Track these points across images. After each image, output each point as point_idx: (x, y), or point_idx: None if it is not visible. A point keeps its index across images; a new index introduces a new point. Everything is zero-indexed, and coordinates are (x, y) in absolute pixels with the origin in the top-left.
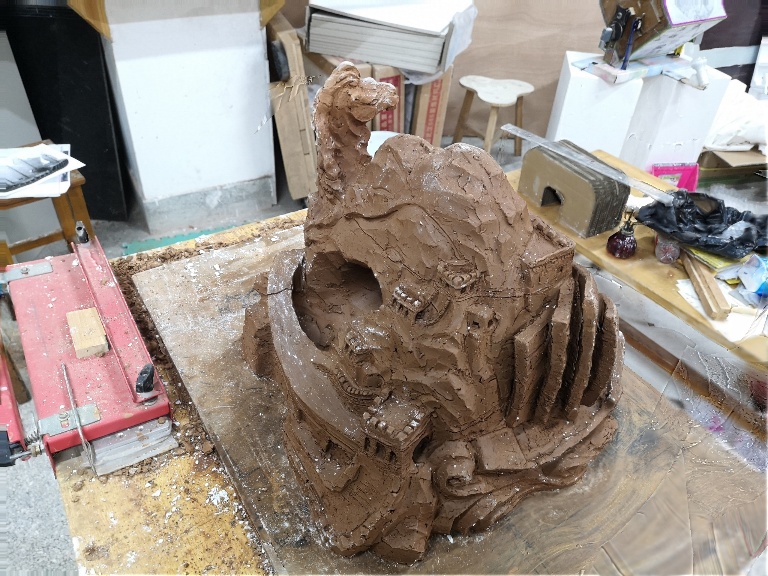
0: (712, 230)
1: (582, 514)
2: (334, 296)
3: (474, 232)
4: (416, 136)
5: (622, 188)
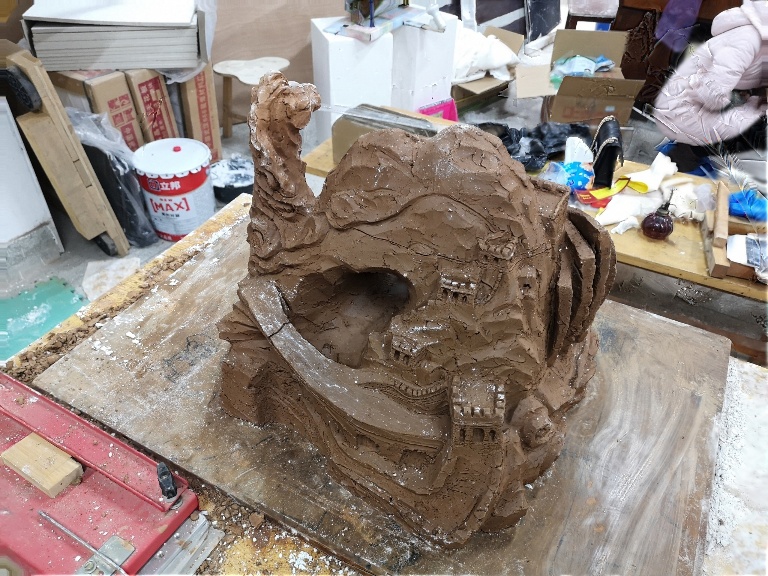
0: (510, 151)
1: (605, 415)
2: (322, 314)
3: (505, 203)
4: None
5: (431, 135)
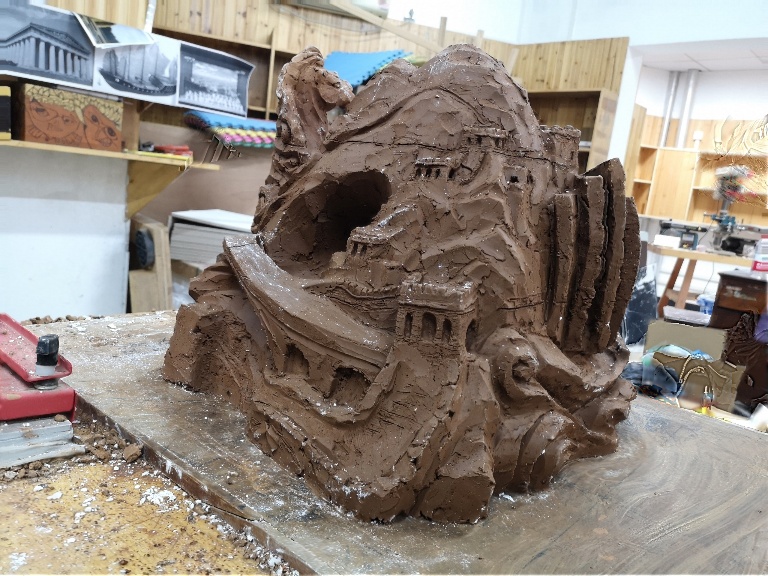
0: None
1: (640, 471)
2: (300, 272)
3: (496, 94)
4: None
5: None
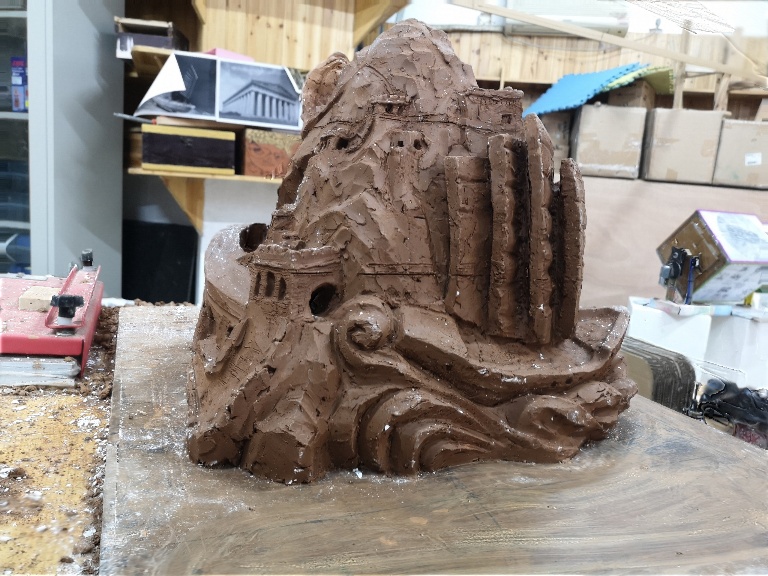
0: None
1: (564, 485)
2: None
3: (406, 61)
4: None
5: (685, 371)
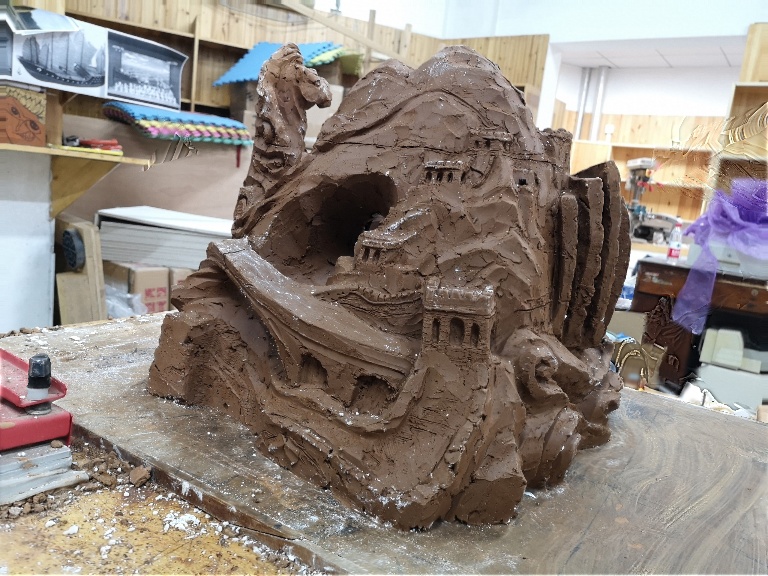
0: None
1: (636, 459)
2: (292, 276)
3: (499, 97)
4: None
5: None
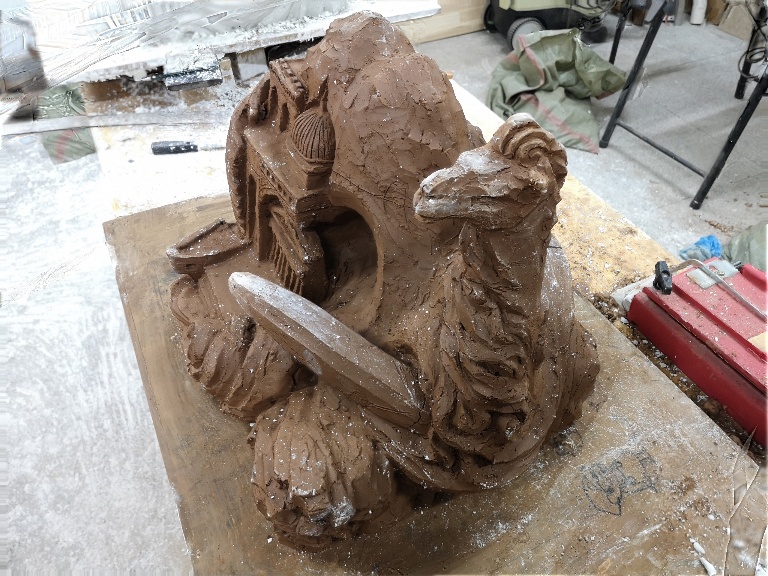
0: None
1: None
2: None
3: None
4: (412, 57)
5: None
